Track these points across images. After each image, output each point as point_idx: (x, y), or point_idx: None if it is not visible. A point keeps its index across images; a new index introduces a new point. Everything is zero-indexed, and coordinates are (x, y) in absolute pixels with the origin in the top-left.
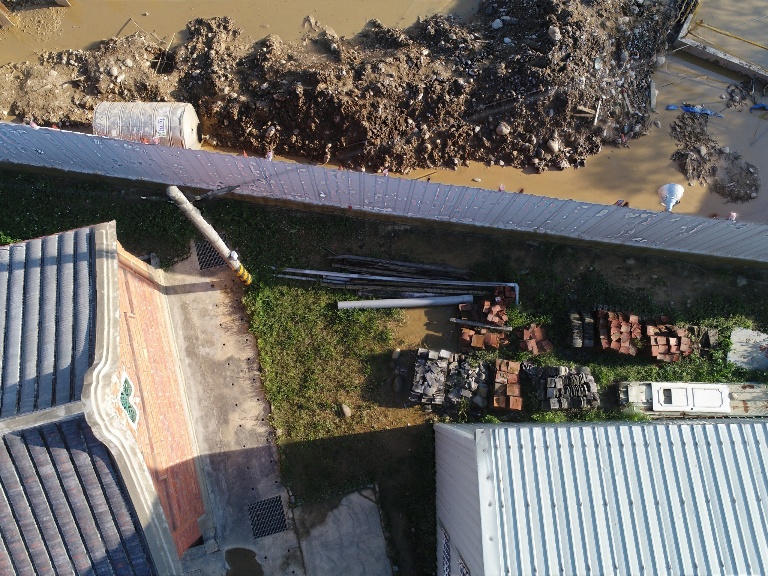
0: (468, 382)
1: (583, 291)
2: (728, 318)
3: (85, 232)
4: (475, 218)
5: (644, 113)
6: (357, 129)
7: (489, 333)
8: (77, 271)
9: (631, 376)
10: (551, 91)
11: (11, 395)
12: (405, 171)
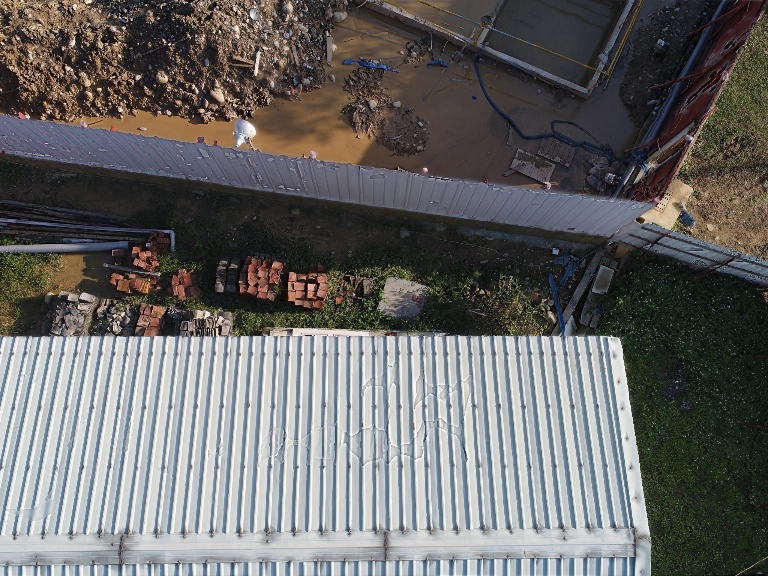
0: (111, 325)
1: (243, 240)
2: (385, 268)
3: None
4: (119, 163)
5: (317, 67)
6: (10, 74)
7: (136, 278)
8: None
9: (277, 322)
10: (197, 39)
11: None
12: (70, 119)
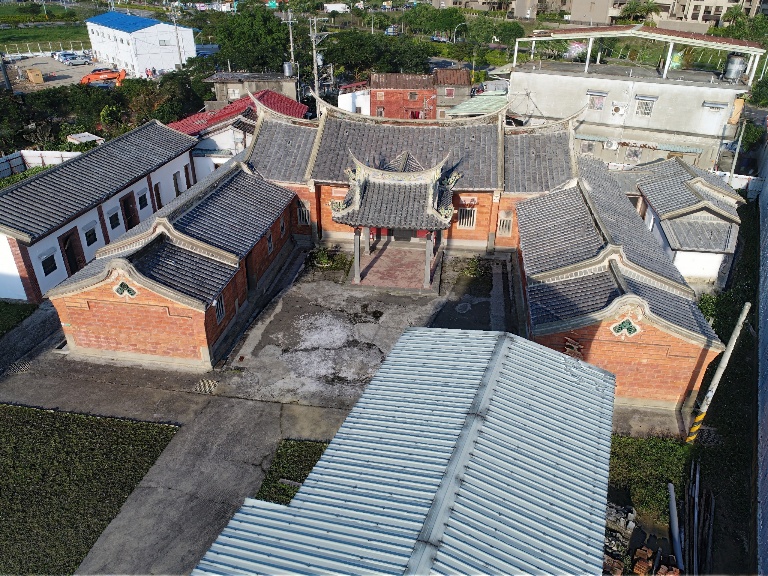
0: None
1: None
2: None
3: (718, 339)
4: None
5: None
6: None
7: None
8: None
9: None
10: None
11: None
12: None
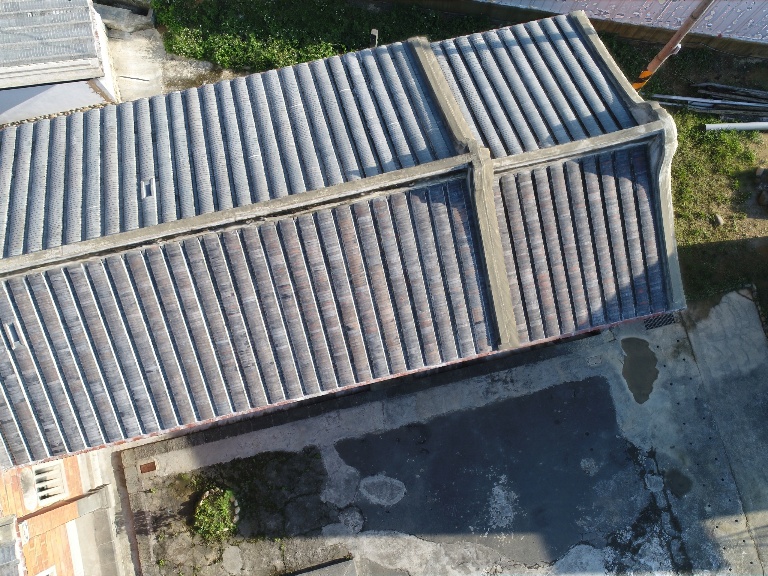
0: None
1: None
2: None
3: (564, 17)
4: None
5: None
6: None
7: None
8: (572, 45)
9: None
10: None
11: (562, 132)
12: None
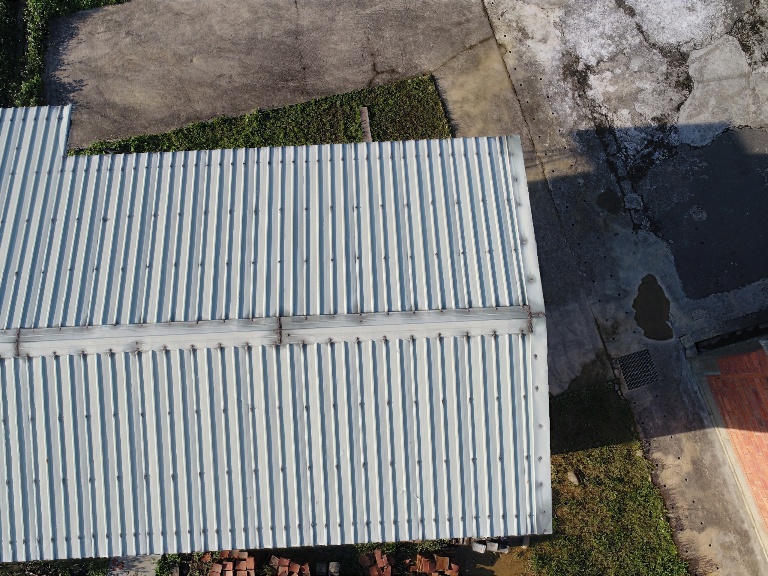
0: None
1: None
2: None
3: None
4: None
5: None
6: None
7: (430, 573)
8: None
9: None
10: None
11: None
12: None
